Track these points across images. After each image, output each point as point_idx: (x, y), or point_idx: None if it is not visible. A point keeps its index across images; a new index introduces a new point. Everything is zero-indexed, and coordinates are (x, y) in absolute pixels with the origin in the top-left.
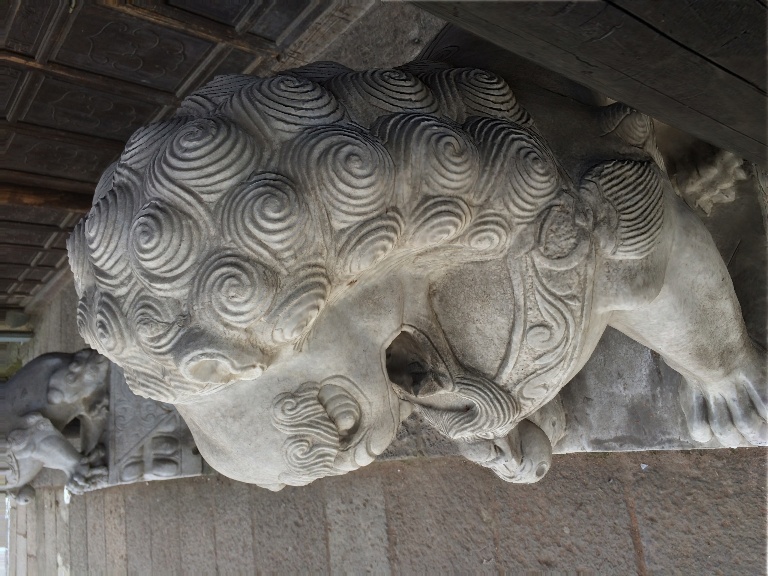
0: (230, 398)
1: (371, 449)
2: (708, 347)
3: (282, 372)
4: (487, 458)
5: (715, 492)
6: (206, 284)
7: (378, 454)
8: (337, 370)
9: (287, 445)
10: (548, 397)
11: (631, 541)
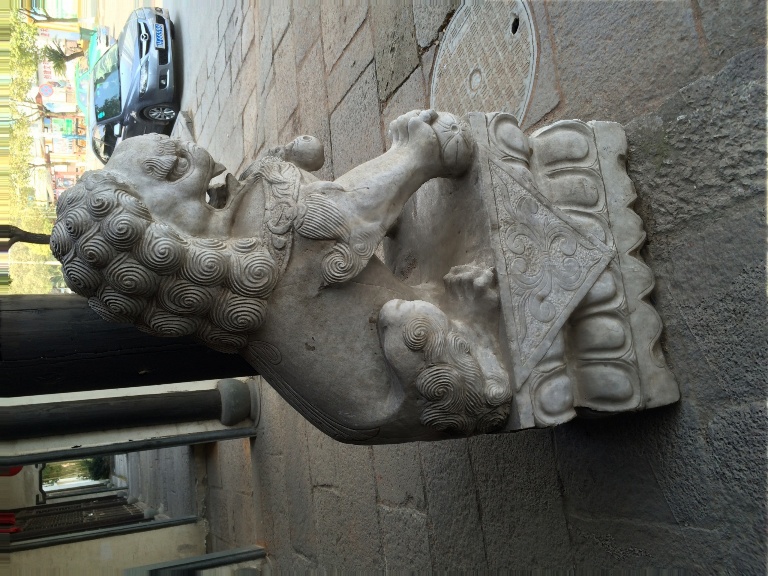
0: None
1: None
2: None
3: None
4: None
5: (635, 95)
6: None
7: None
8: None
9: None
10: None
11: (699, 4)
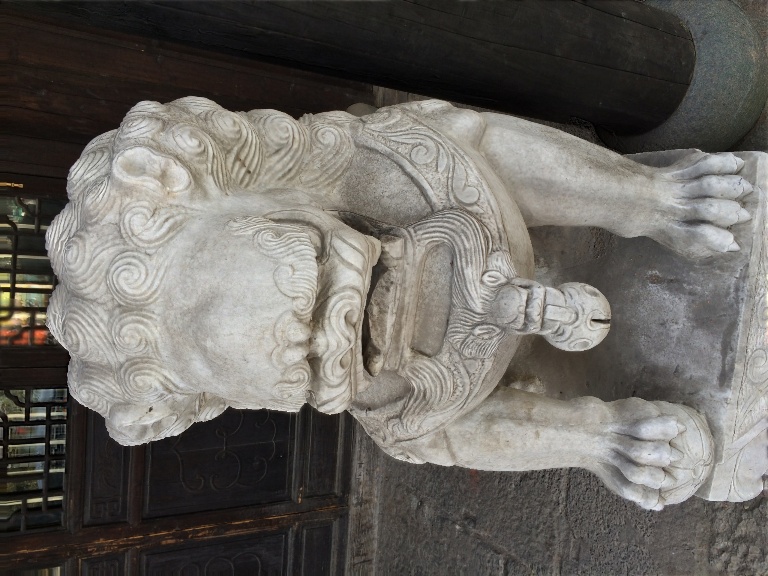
0: (189, 240)
1: (347, 241)
2: (598, 160)
3: (222, 212)
4: (520, 295)
5: None
6: (115, 140)
7: (361, 249)
8: (272, 208)
9: (255, 239)
10: (489, 200)
11: None
